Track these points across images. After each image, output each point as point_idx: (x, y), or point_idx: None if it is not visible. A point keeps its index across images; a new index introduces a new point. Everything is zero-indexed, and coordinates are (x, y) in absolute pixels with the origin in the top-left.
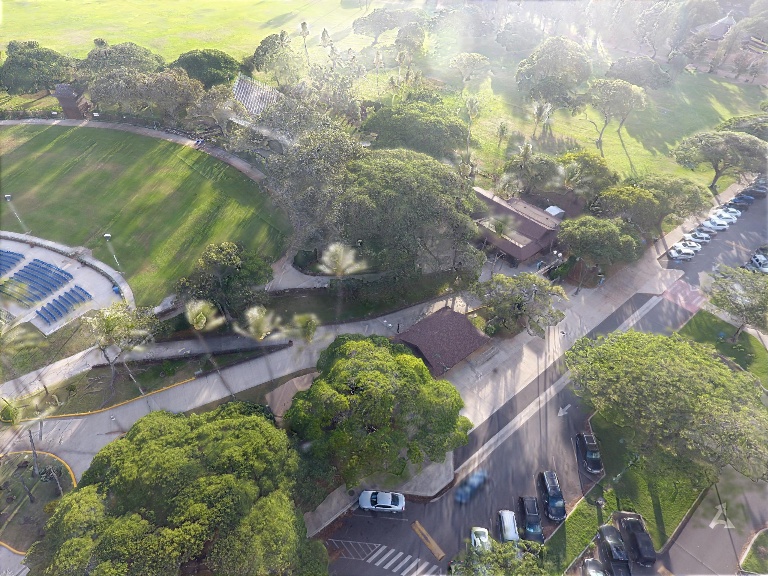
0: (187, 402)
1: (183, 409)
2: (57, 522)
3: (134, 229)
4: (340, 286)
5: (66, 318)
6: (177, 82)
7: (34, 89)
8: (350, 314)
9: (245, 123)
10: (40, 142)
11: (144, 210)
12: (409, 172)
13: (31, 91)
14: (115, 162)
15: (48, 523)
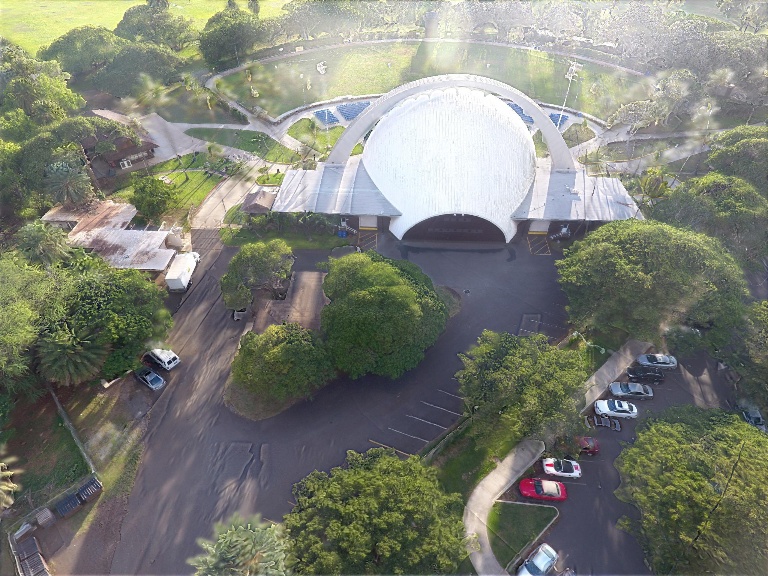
0: (677, 156)
1: (678, 158)
2: (743, 148)
3: (552, 89)
4: (727, 105)
5: (563, 127)
6: (523, 5)
7: (371, 23)
8: (730, 124)
9: (564, 35)
10: (426, 50)
11: (547, 81)
12: (761, 37)
13: (370, 25)
14: (492, 59)
15: (735, 151)
